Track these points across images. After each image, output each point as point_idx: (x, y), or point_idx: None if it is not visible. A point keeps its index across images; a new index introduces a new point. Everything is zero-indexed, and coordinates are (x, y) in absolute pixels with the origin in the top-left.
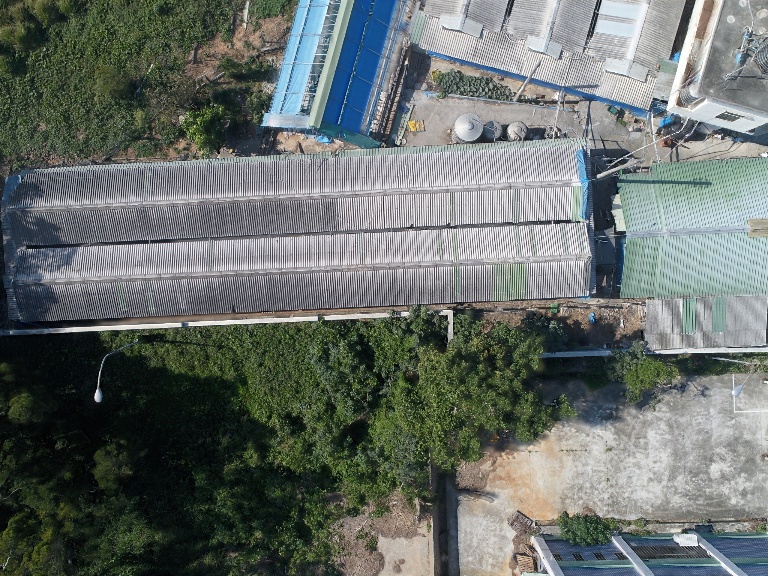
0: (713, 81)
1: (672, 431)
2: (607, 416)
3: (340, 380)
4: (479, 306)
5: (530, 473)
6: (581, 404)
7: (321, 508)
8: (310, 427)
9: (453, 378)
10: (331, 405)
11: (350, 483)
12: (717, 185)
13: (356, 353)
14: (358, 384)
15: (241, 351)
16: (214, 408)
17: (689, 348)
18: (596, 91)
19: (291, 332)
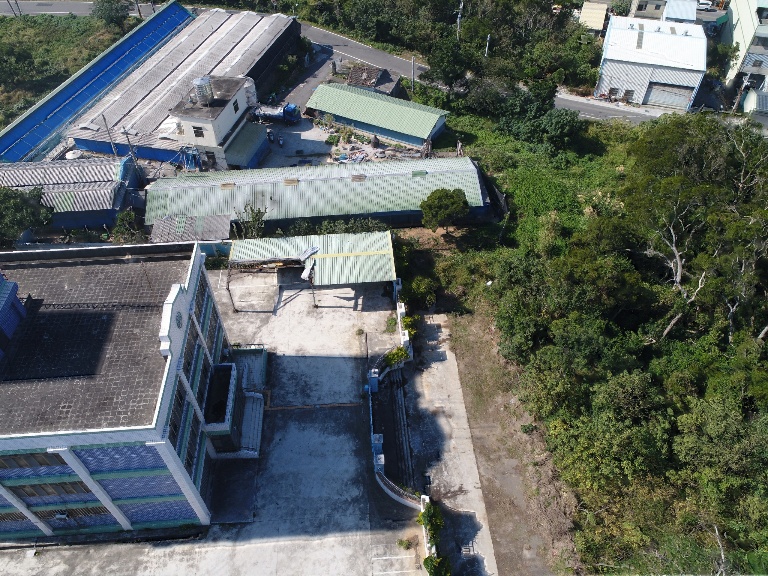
0: (178, 110)
1: None
2: None
3: None
4: None
5: None
6: None
7: None
8: None
9: None
10: None
11: None
12: (212, 176)
13: None
14: None
15: None
16: None
17: None
18: (153, 146)
19: None
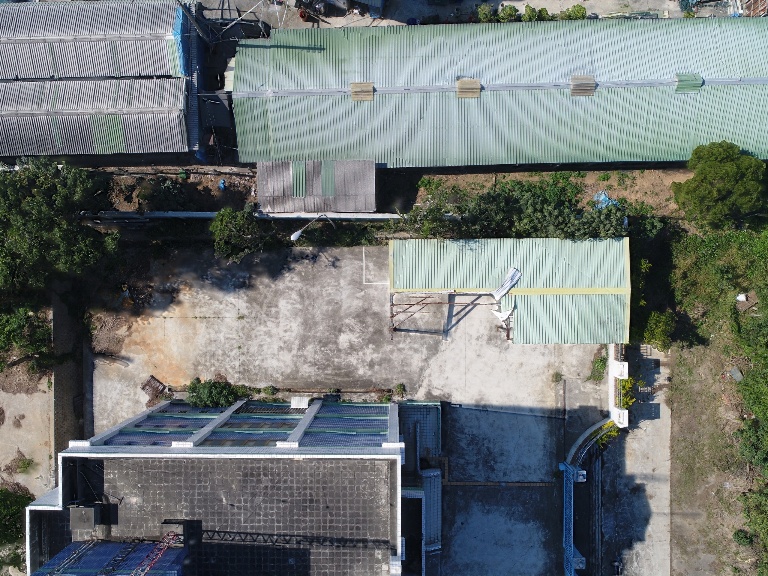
0: None
1: (303, 301)
2: (240, 284)
3: None
4: (110, 169)
5: (164, 339)
6: (215, 272)
7: None
8: None
9: None
10: None
11: None
12: (330, 51)
13: None
14: None
15: None
16: None
17: (302, 212)
18: None
19: None
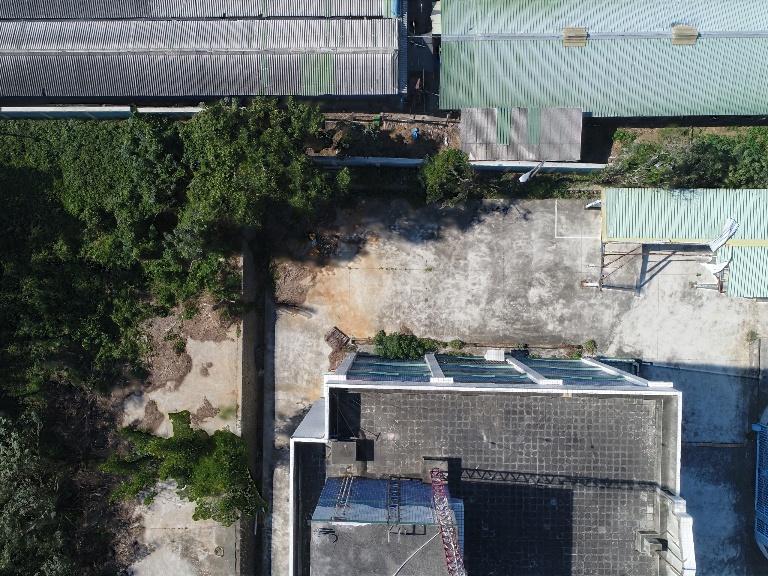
0: None
1: (492, 254)
2: (428, 236)
3: (149, 171)
4: None
5: (349, 290)
6: (403, 222)
7: (129, 305)
8: (120, 220)
9: (223, 131)
10: (139, 196)
11: (161, 283)
12: None
13: (162, 140)
14: (165, 174)
15: (57, 143)
16: (28, 200)
17: (504, 160)
18: None
19: (109, 128)
